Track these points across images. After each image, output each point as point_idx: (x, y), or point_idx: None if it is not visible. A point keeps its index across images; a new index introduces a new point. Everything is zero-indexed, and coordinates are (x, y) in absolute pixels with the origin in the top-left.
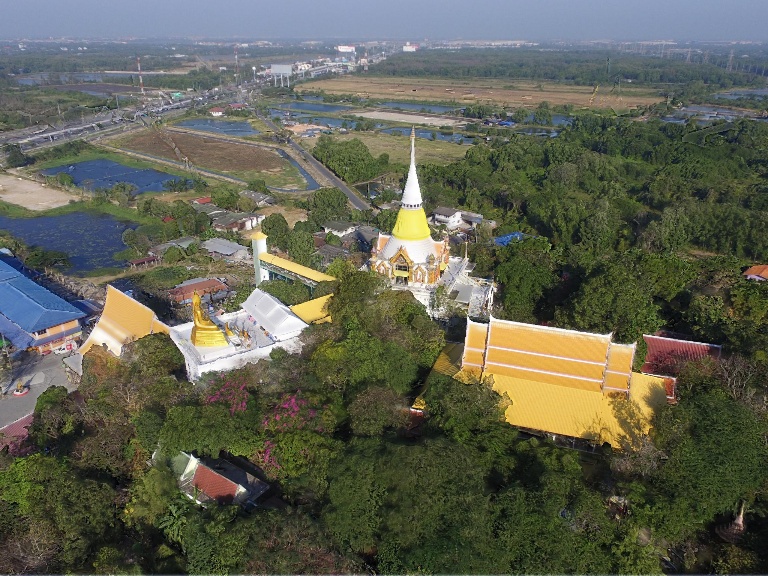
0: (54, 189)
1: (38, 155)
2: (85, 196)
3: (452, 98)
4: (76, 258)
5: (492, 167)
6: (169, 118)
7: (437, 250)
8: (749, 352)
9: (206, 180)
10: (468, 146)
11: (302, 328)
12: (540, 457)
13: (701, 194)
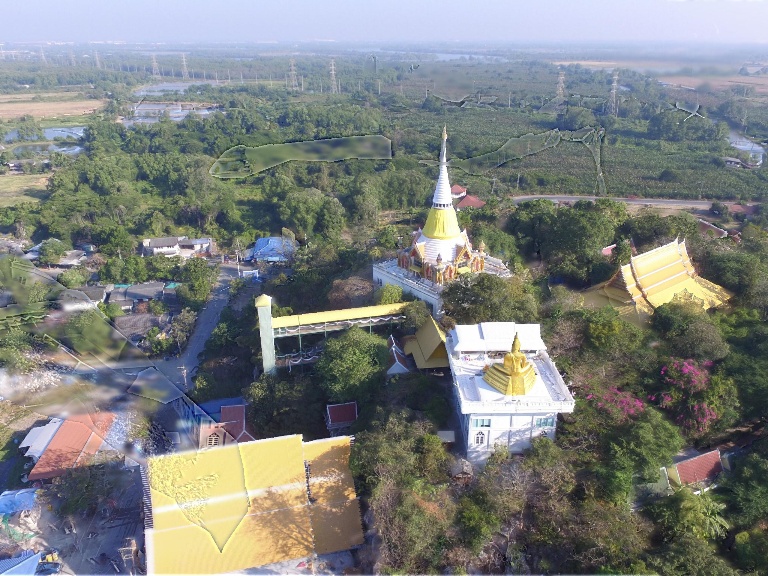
0: None
1: None
2: None
3: None
4: None
5: (92, 191)
6: None
7: (464, 240)
8: (666, 232)
9: None
10: None
11: None
12: None
13: (314, 172)
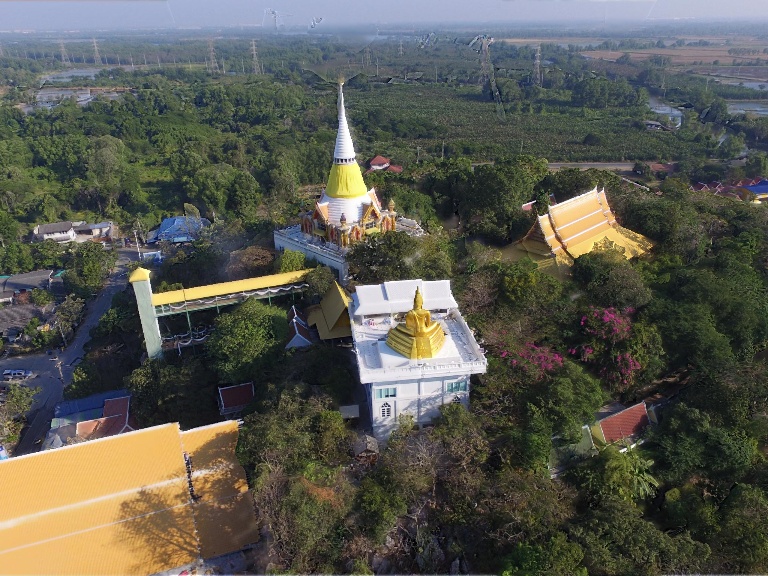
0: None
1: None
2: None
3: None
4: None
5: None
6: None
7: None
8: (587, 185)
9: None
10: None
11: None
12: (672, 264)
13: None
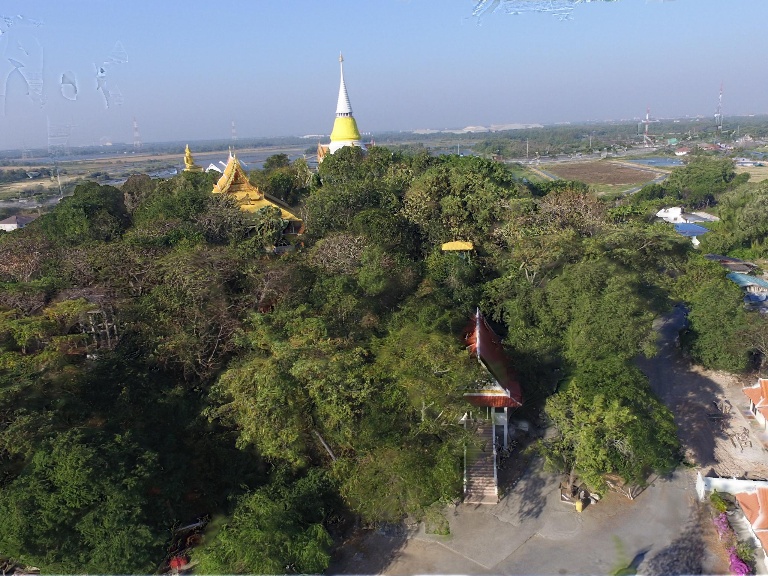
0: None
1: None
2: None
3: None
4: None
5: None
6: (628, 155)
7: None
8: None
9: None
10: None
11: None
12: None
13: None
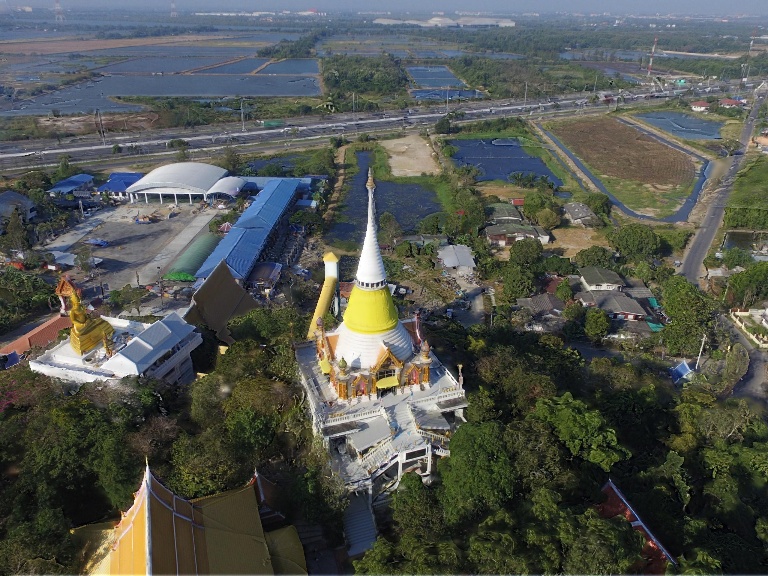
0: (434, 159)
1: (467, 126)
2: (443, 171)
3: None
4: (352, 226)
5: None
6: (638, 107)
7: (378, 356)
8: None
9: (567, 181)
10: None
11: (131, 373)
12: None
13: None
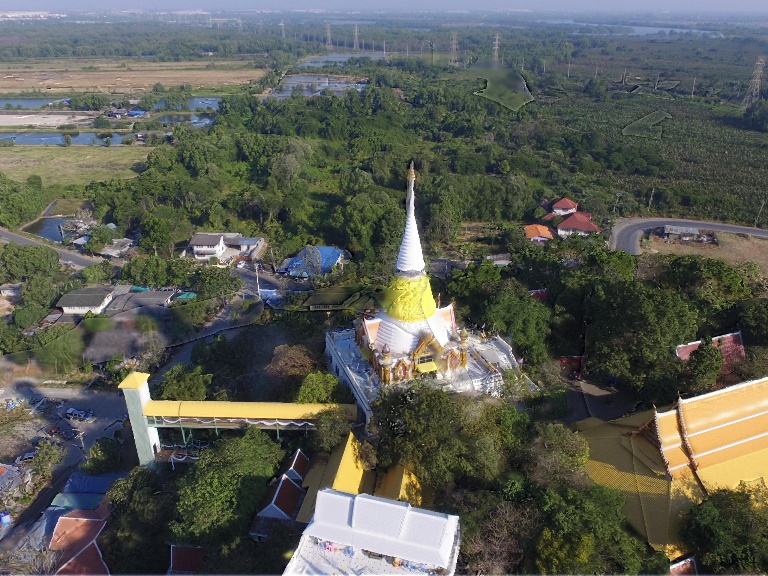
0: None
1: None
2: None
3: (30, 87)
4: None
5: (186, 170)
6: None
7: (447, 319)
8: None
9: None
10: (121, 147)
11: (456, 527)
12: None
13: None
